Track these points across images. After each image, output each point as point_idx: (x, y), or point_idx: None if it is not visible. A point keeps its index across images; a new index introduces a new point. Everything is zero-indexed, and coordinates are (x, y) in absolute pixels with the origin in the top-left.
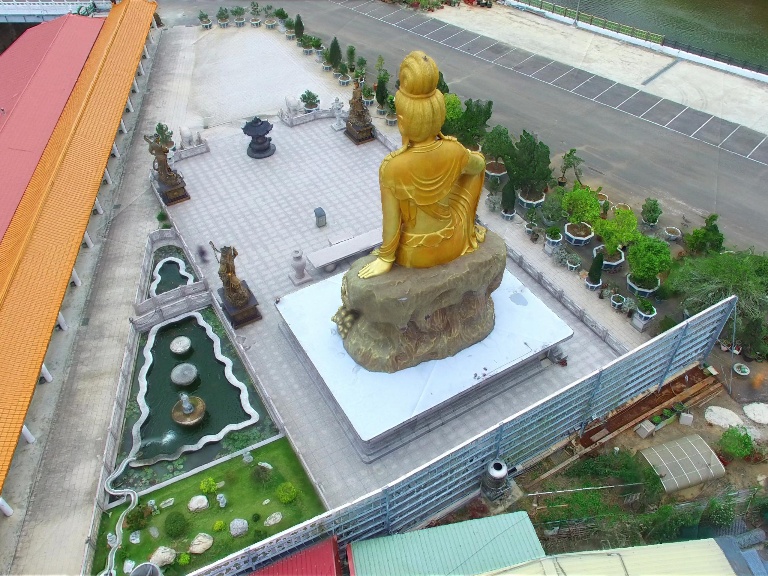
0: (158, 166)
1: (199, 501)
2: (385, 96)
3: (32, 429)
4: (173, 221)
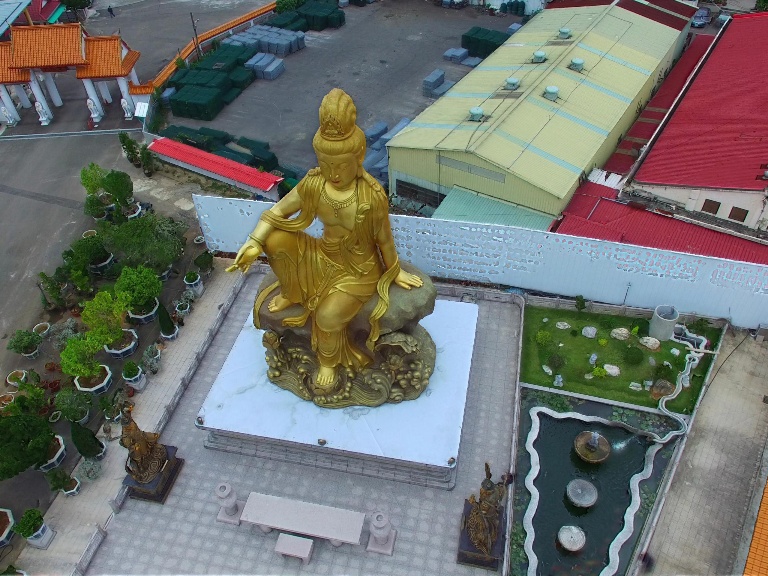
0: None
1: (611, 369)
2: None
3: None
4: None
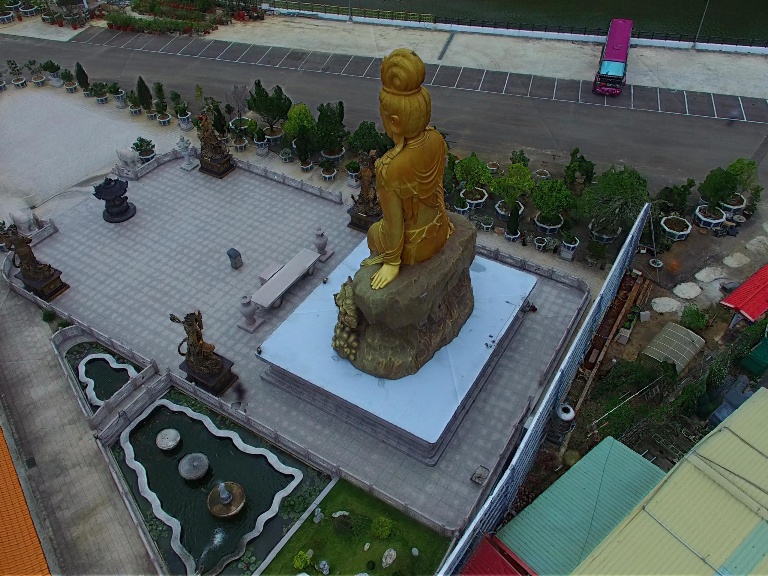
0: (21, 262)
1: None
2: (224, 124)
3: None
4: (70, 316)
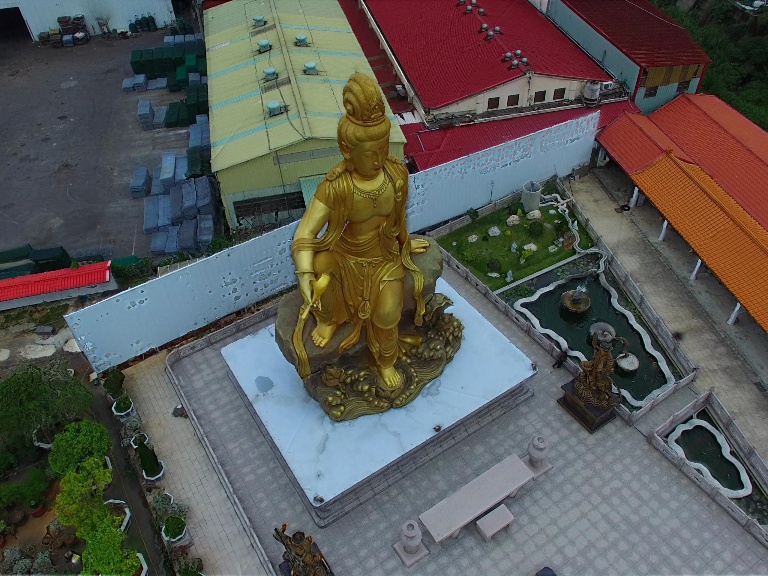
0: None
1: (530, 247)
2: None
3: (702, 285)
4: None
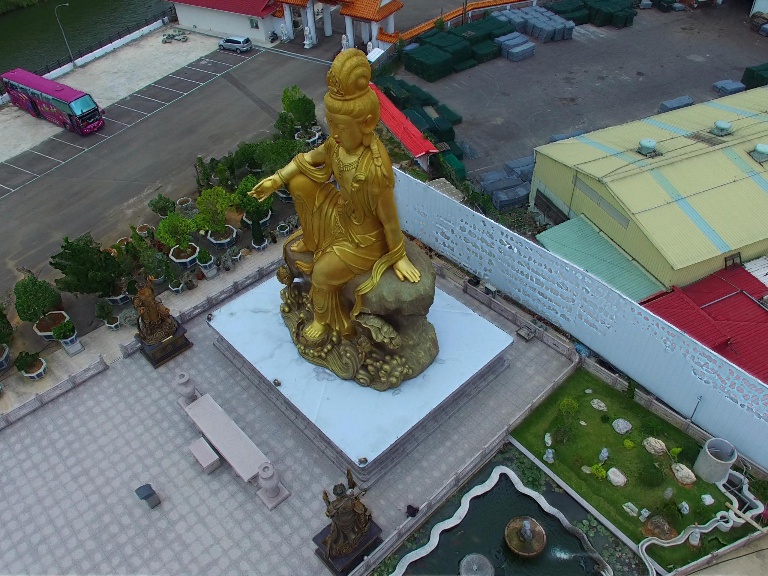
0: None
1: (616, 475)
2: None
3: None
4: None
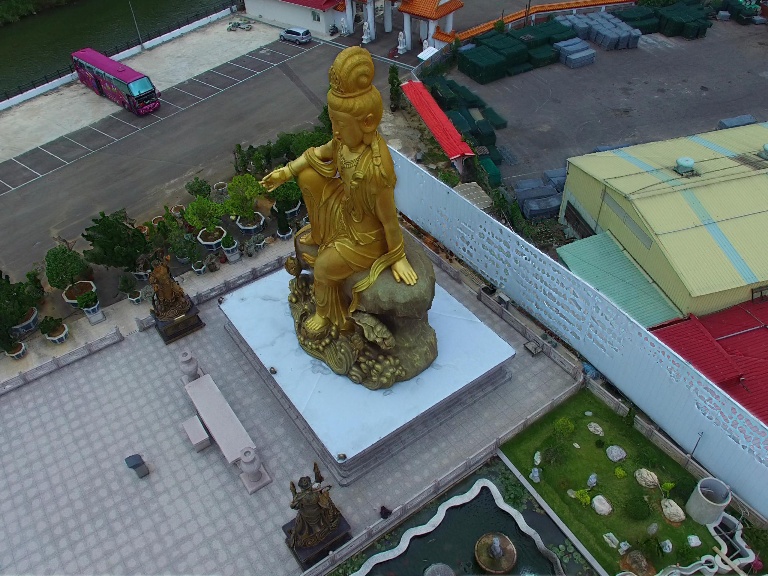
0: None
1: (601, 503)
2: None
3: None
4: None
